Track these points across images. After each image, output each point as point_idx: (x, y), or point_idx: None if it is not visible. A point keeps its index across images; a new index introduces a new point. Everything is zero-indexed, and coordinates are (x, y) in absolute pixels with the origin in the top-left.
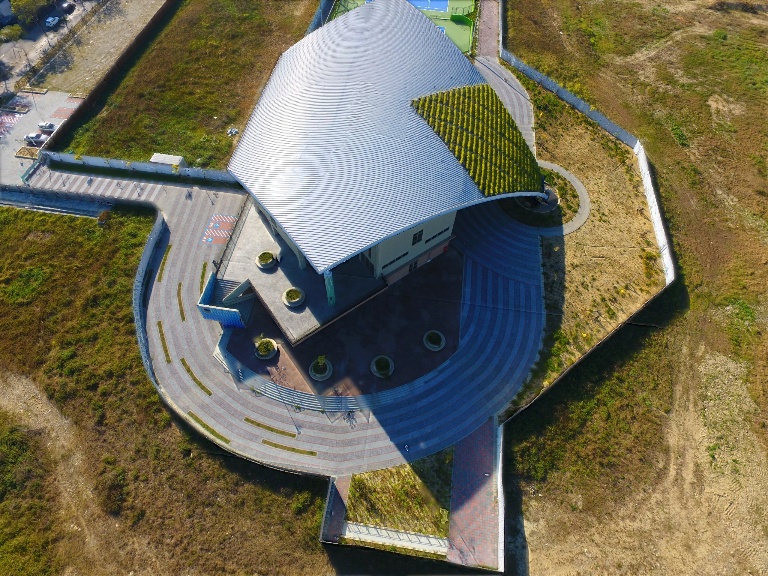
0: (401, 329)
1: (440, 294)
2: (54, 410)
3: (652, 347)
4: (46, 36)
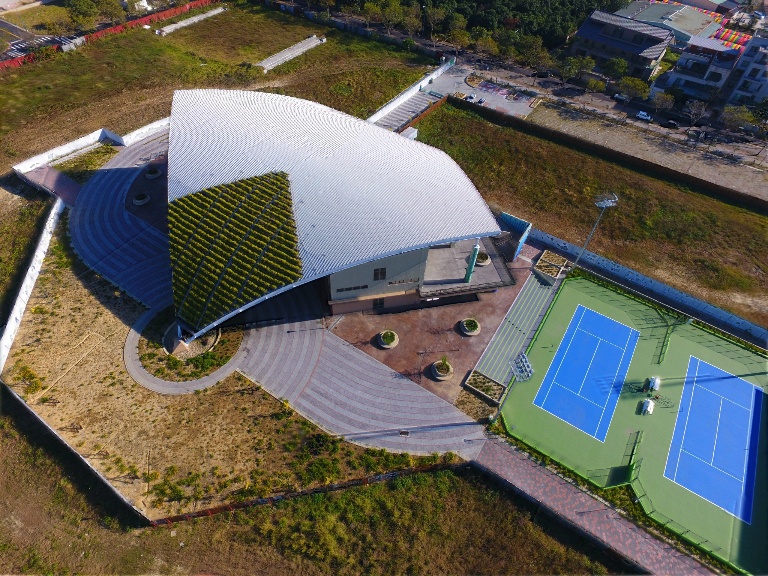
0: None
1: None
2: None
3: None
4: (619, 113)
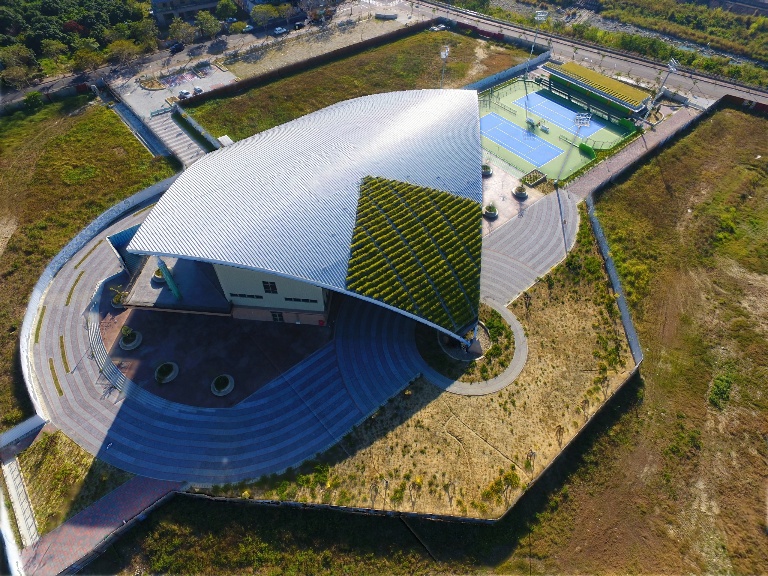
0: (214, 357)
1: (275, 355)
2: (2, 252)
3: (399, 565)
4: (267, 38)
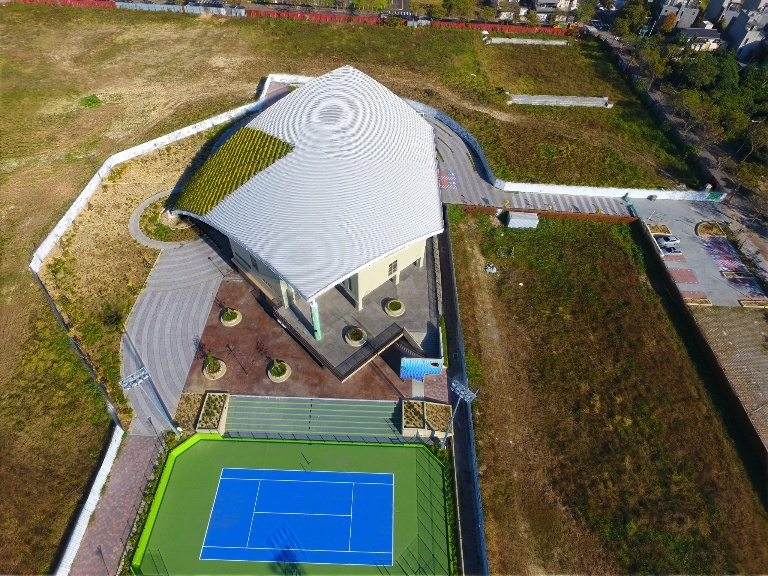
0: None
1: None
2: None
3: None
4: None
